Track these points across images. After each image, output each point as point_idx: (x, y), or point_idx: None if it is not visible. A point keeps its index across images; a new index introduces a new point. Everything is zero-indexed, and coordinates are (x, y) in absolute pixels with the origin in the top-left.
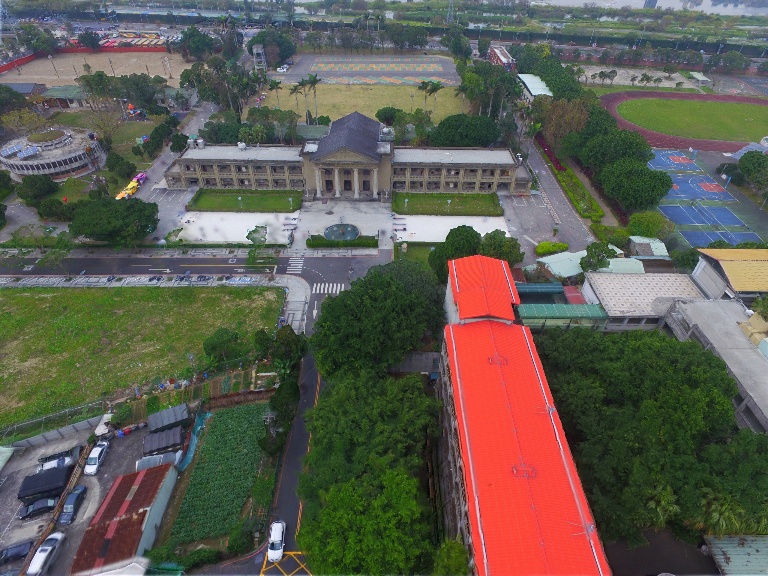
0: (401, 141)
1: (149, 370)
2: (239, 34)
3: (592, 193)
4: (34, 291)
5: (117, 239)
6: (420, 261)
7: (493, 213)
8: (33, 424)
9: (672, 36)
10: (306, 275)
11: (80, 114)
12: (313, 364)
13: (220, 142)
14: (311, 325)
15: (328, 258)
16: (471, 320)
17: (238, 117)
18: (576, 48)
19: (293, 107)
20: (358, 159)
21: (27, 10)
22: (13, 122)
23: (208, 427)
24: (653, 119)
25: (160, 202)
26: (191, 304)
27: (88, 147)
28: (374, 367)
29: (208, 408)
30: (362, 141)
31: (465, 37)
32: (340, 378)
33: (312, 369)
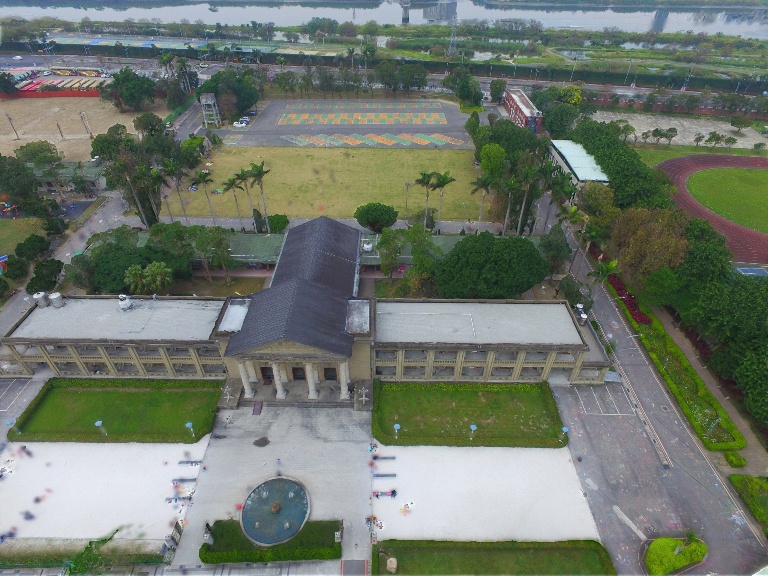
0: (390, 268)
1: None
2: (192, 74)
3: (706, 379)
4: None
5: None
6: None
7: (550, 444)
8: None
9: (717, 69)
10: None
11: None
12: None
13: (98, 286)
14: None
15: None
16: None
17: (137, 235)
18: (613, 92)
19: None
20: (311, 351)
21: None
22: None
23: None
24: (744, 206)
25: None
26: None
27: None
28: None
29: None
30: (320, 309)
31: (474, 79)
32: None
33: None
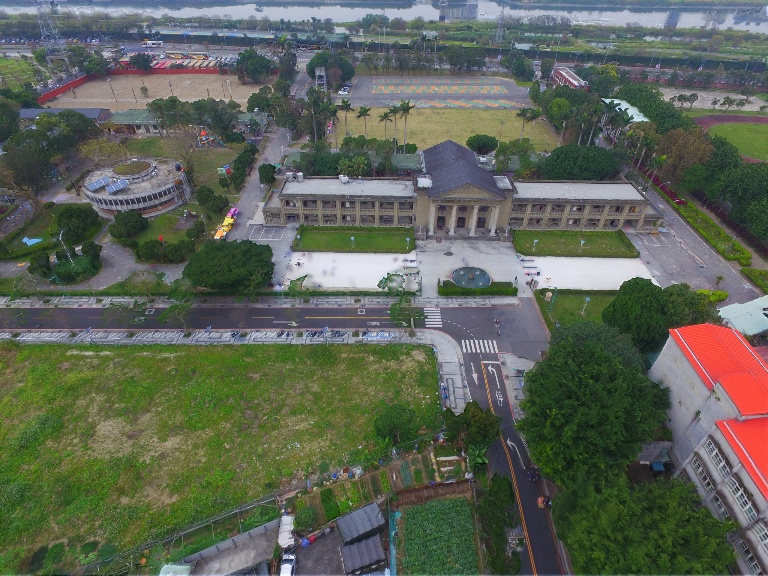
0: (502, 172)
1: (311, 453)
2: (293, 55)
3: (725, 231)
4: (154, 350)
5: (239, 289)
6: (570, 312)
7: (629, 255)
8: (201, 530)
9: (728, 56)
10: (449, 329)
11: (149, 140)
12: (497, 445)
13: (316, 174)
14: (477, 393)
15: (466, 308)
16: (754, 416)
17: None
18: (643, 70)
19: (368, 133)
20: (481, 196)
21: (76, 31)
22: (94, 152)
23: (402, 532)
24: (751, 146)
25: (261, 241)
26: (333, 366)
27: (178, 180)
28: (612, 465)
29: (396, 506)
30: (481, 175)
31: (528, 59)
32: (582, 482)
33: (498, 452)
